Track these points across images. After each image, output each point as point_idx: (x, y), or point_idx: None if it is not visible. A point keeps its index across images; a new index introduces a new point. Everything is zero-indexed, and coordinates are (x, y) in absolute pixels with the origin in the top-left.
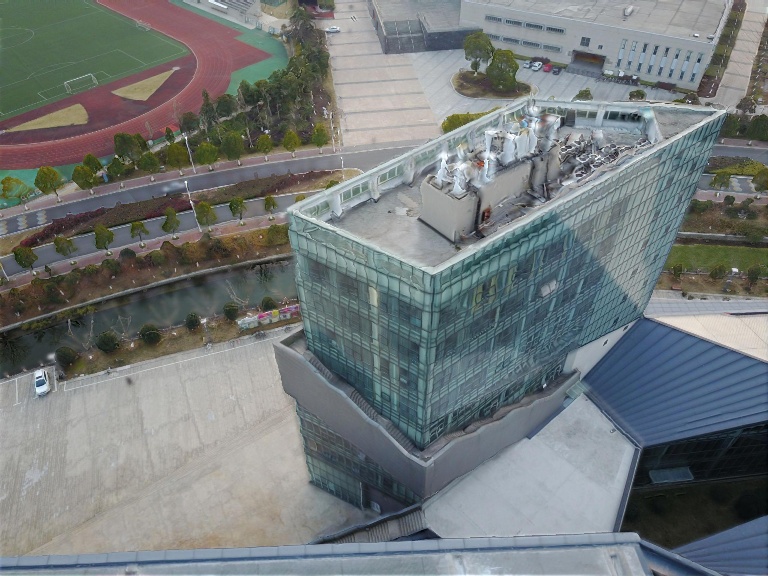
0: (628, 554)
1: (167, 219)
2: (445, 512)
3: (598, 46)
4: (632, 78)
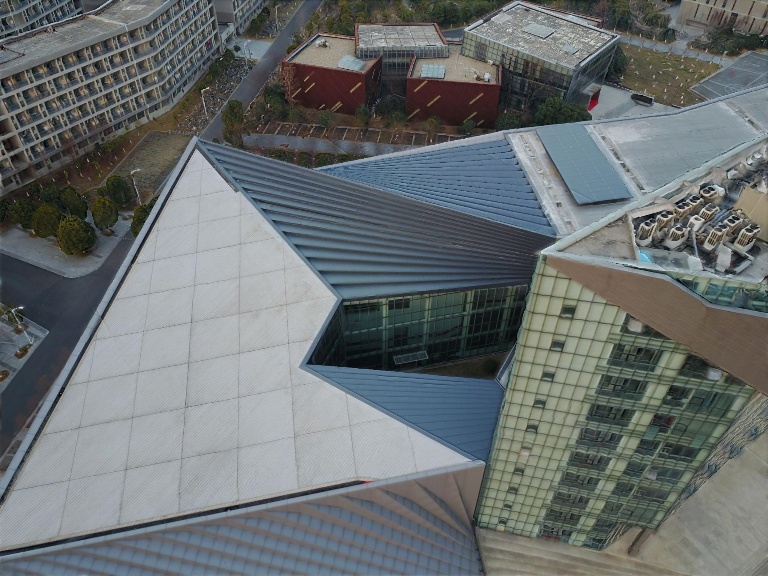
0: (565, 231)
1: None
2: None
3: None
4: None
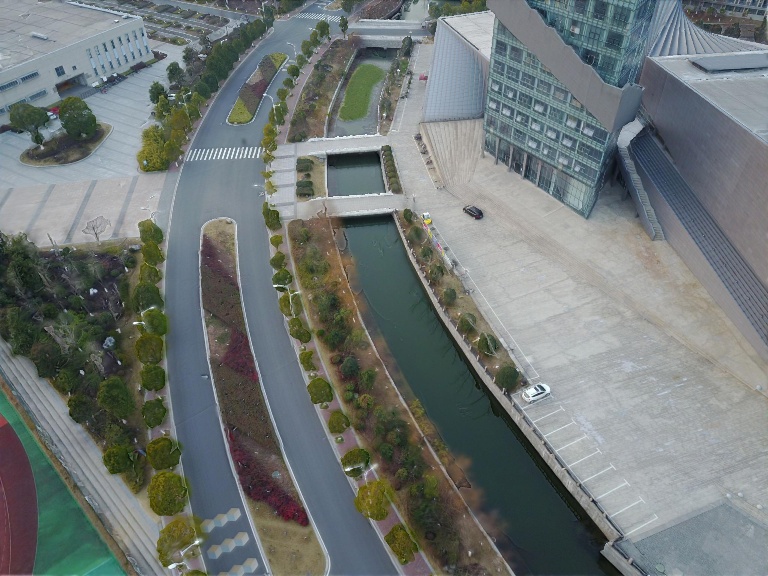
0: (656, 58)
1: (300, 330)
2: None
3: (72, 68)
4: (115, 76)
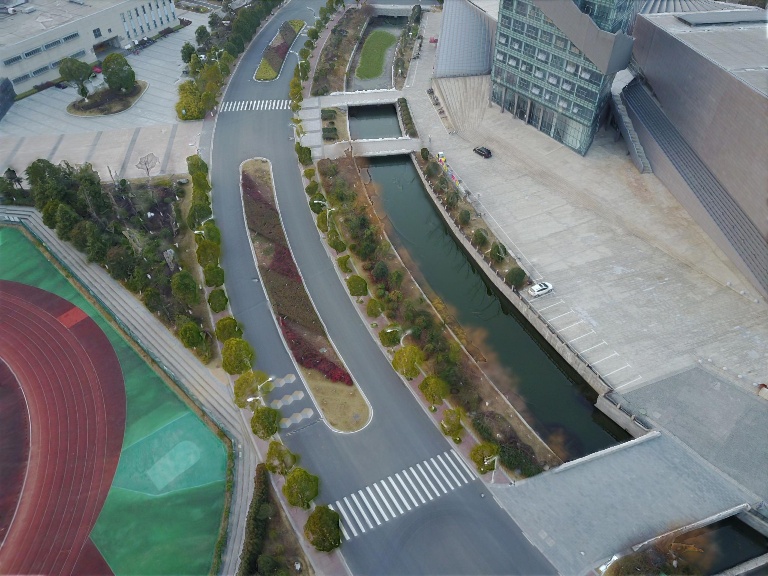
0: None
1: (337, 240)
2: None
3: (108, 31)
4: (145, 40)
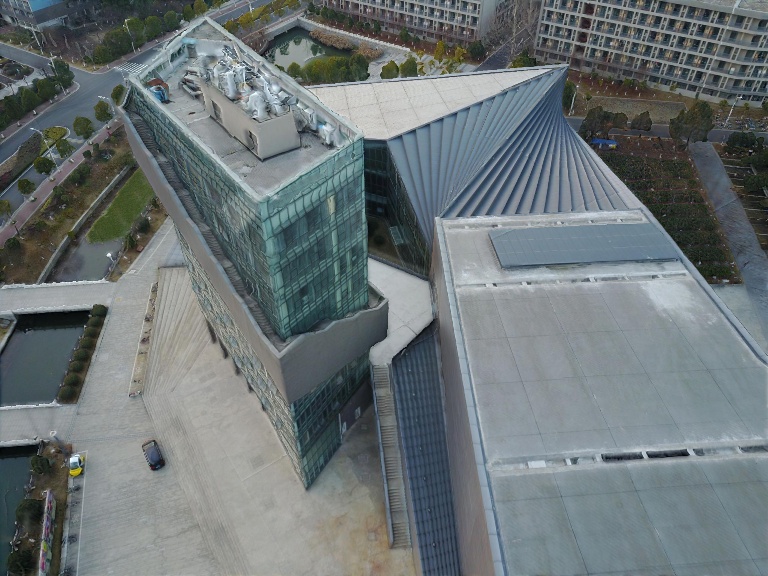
0: (448, 223)
1: None
2: (375, 353)
3: None
4: None
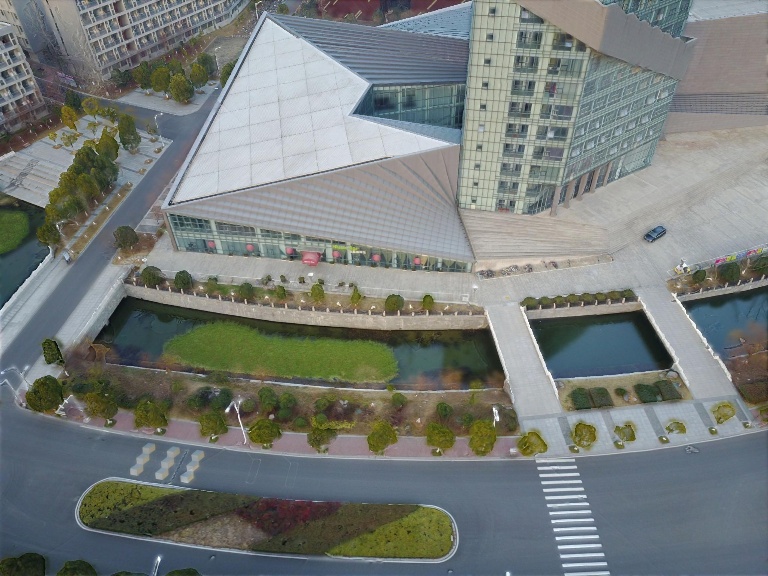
0: None
1: None
2: None
3: None
4: None
